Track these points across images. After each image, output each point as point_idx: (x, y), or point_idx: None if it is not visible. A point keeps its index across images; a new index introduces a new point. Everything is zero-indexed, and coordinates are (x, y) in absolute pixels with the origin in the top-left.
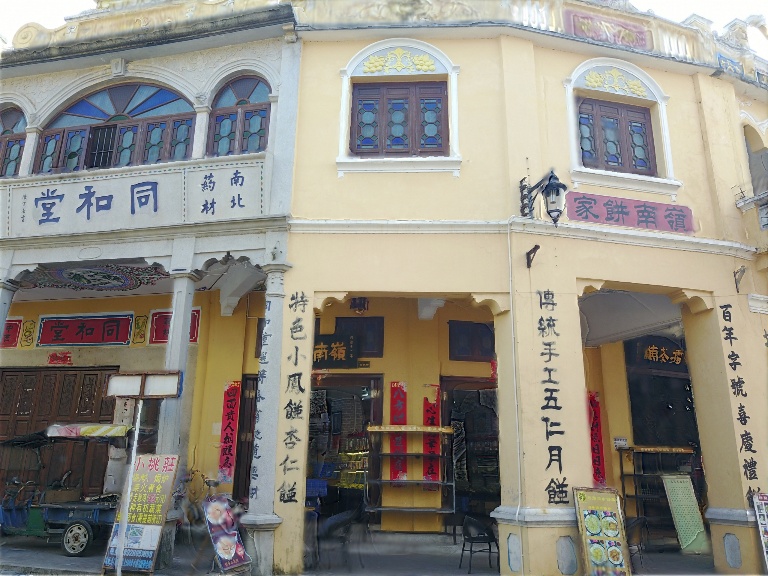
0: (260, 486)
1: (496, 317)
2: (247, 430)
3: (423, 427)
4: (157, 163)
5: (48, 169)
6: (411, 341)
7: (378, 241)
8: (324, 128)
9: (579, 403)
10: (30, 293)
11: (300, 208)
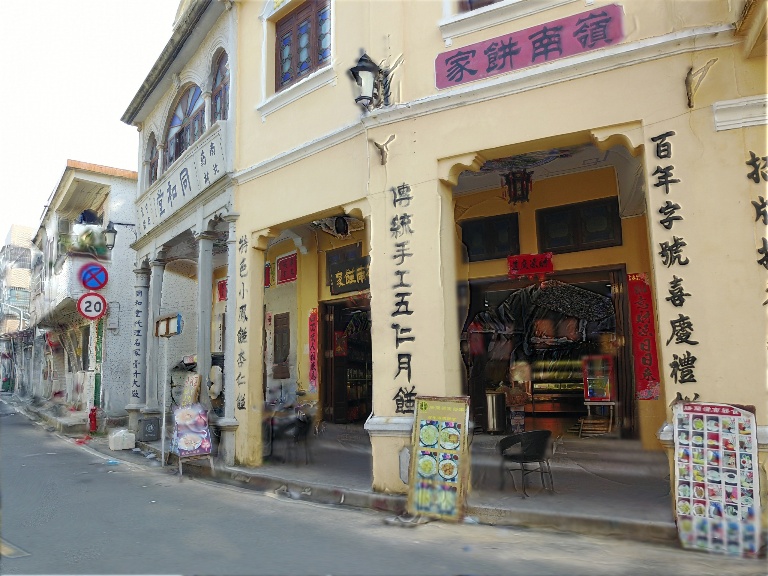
0: (226, 397)
1: None
2: (329, 348)
3: None
4: None
5: None
6: None
7: (285, 174)
8: (256, 79)
9: (433, 305)
10: (219, 259)
11: (244, 161)
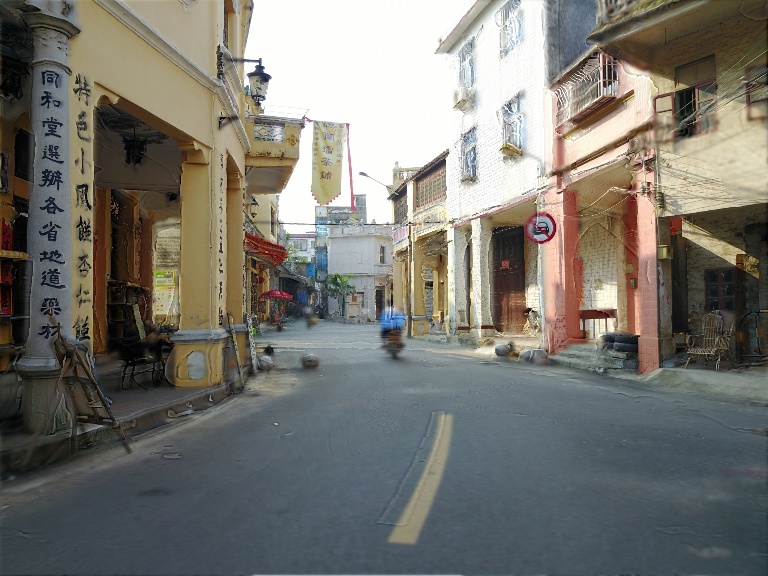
0: (63, 322)
1: (185, 164)
2: None
3: None
4: None
5: None
6: None
7: (141, 48)
8: None
9: (225, 249)
10: None
11: None
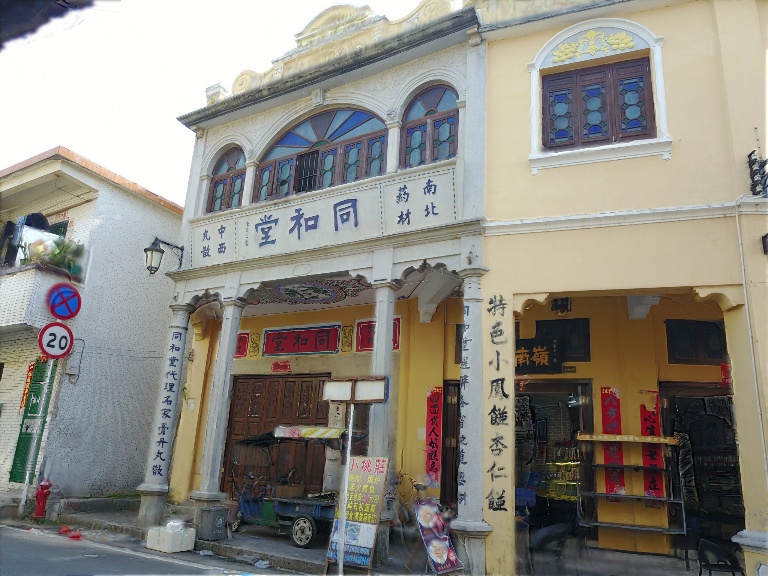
0: (468, 492)
1: (726, 313)
2: (451, 436)
3: (641, 437)
4: (355, 181)
5: (264, 197)
6: (622, 343)
7: (579, 237)
8: (514, 126)
9: None
10: (255, 309)
11: (494, 210)
